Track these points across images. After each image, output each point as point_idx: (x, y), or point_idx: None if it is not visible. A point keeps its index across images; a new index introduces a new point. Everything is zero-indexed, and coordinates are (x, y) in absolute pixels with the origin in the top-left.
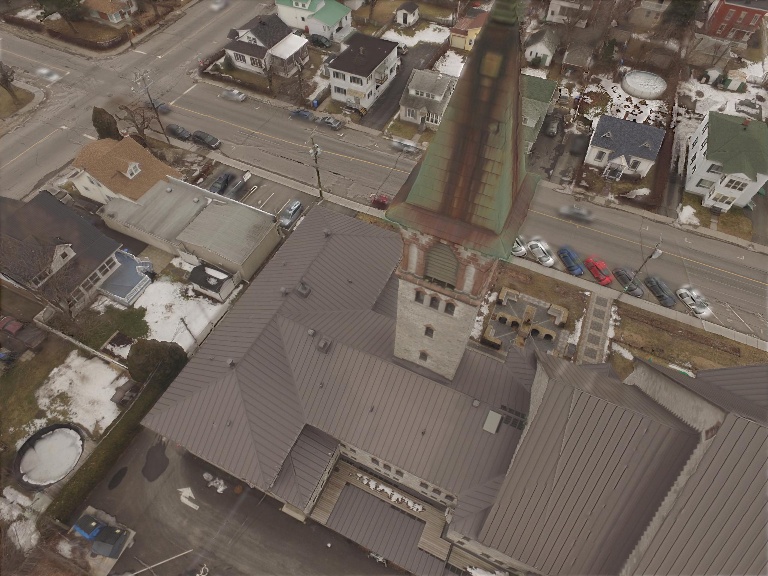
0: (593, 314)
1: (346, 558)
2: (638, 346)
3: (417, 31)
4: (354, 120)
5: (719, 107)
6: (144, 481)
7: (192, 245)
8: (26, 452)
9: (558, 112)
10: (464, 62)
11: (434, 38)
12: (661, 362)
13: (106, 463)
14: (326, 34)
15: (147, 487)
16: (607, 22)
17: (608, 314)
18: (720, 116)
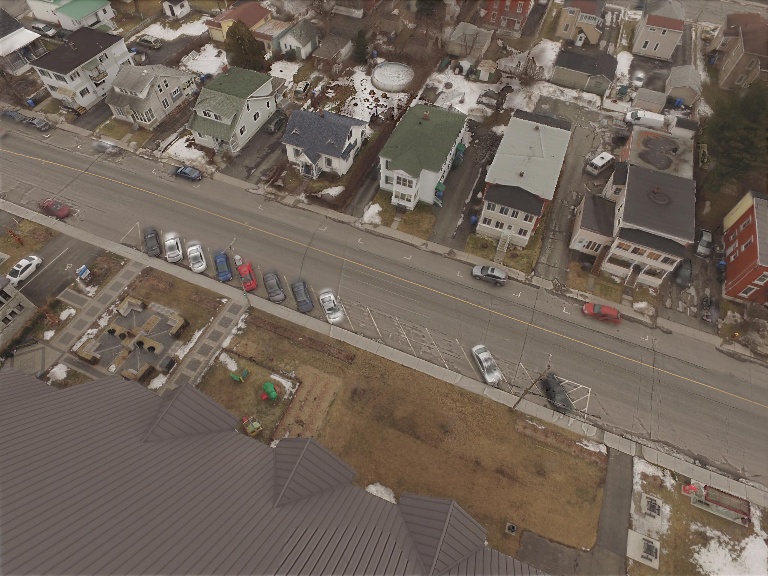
0: (218, 323)
1: None
2: (247, 356)
3: (184, 24)
4: (68, 120)
5: (460, 99)
6: None
7: None
8: None
9: (284, 107)
10: (217, 56)
11: (198, 31)
12: (264, 372)
13: None
14: (77, 28)
15: None
16: (388, 12)
17: (235, 322)
18: (418, 109)
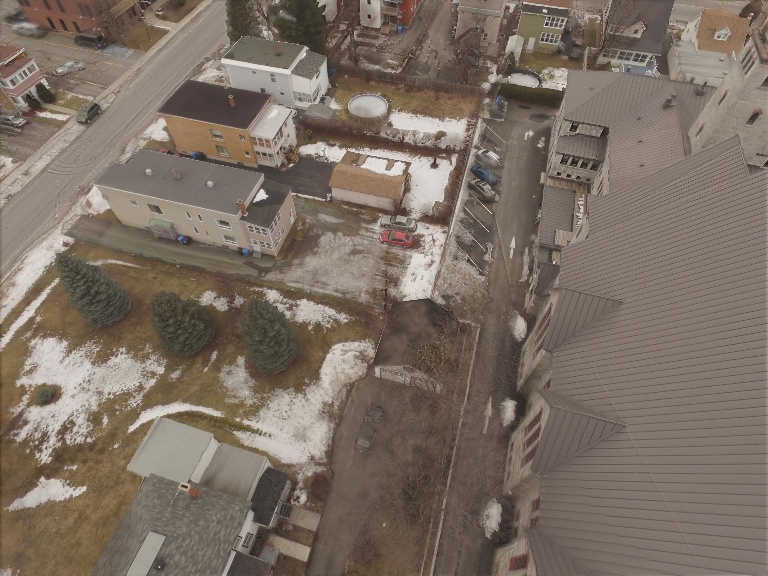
0: None
1: (531, 205)
2: None
3: None
4: None
5: None
6: (528, 116)
7: (687, 81)
8: (520, 73)
9: None
10: None
11: None
12: None
13: (532, 95)
14: None
15: (526, 118)
16: None
17: None
18: None
